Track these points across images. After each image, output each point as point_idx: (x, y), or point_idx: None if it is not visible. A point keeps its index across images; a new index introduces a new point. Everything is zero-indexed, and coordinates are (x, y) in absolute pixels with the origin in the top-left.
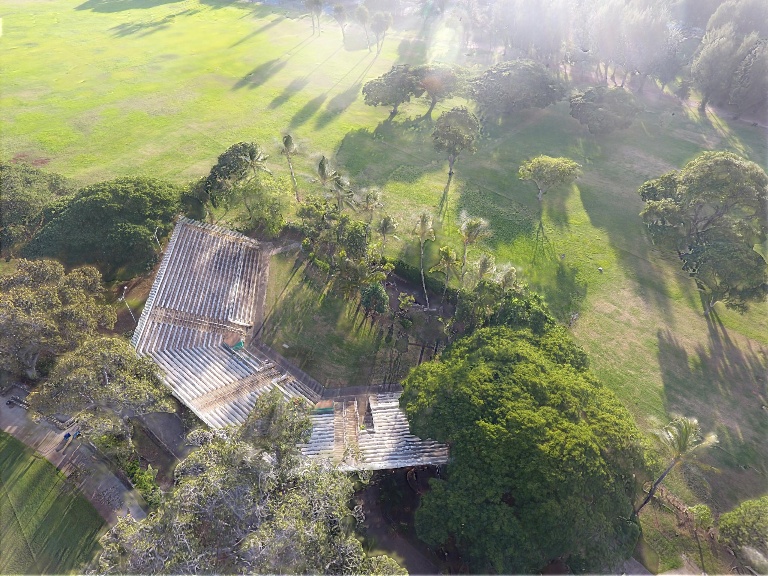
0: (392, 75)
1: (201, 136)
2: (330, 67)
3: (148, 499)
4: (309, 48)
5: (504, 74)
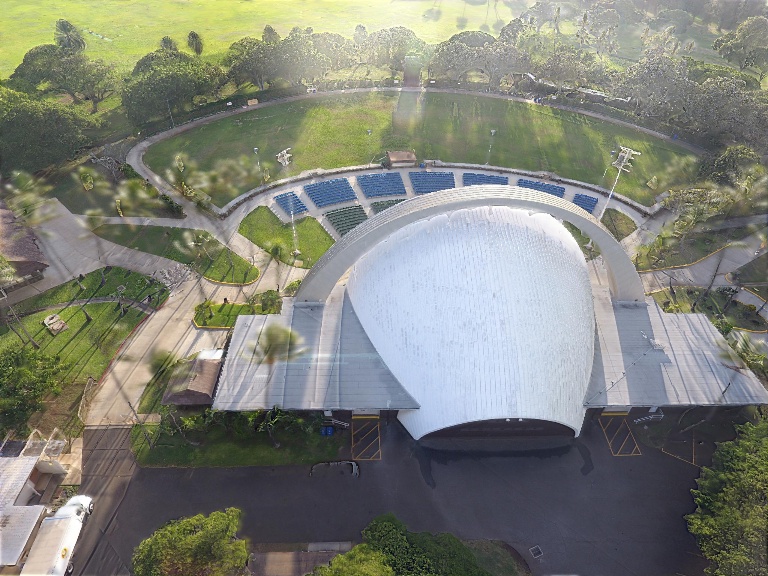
0: (541, 6)
1: (436, 40)
2: (472, 13)
3: (592, 103)
4: (445, 4)
5: (611, 3)
